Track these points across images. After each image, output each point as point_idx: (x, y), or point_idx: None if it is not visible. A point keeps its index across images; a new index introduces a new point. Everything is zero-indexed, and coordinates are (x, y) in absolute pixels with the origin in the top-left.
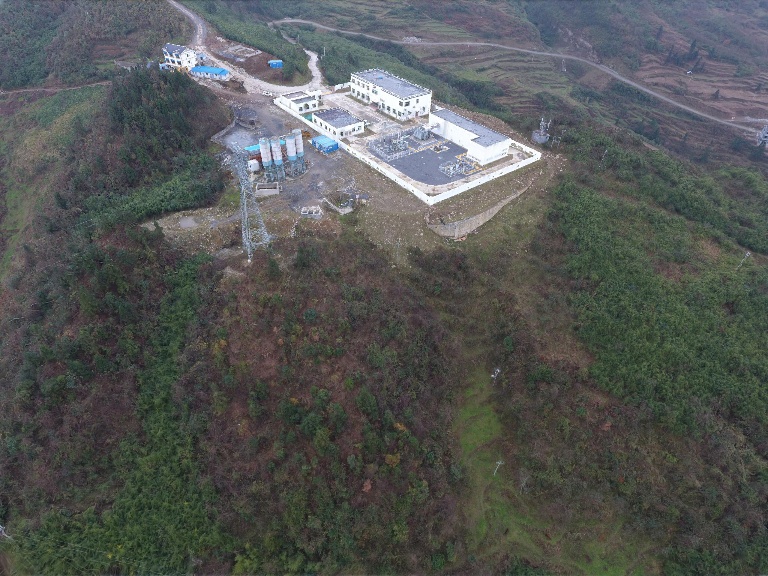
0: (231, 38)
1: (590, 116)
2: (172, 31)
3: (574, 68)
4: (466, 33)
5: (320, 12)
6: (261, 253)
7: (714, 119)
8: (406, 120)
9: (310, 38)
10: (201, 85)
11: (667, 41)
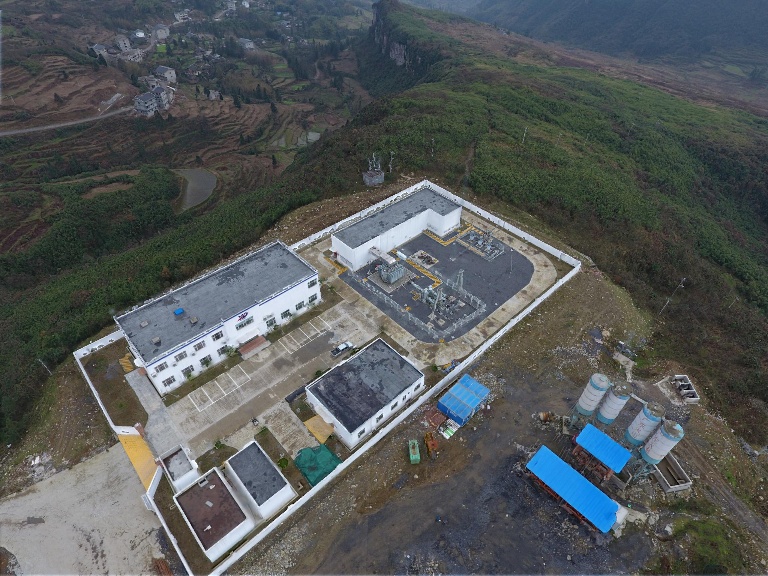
0: None
1: None
2: None
3: None
4: None
5: None
6: None
7: (93, 119)
8: None
9: None
10: None
11: None
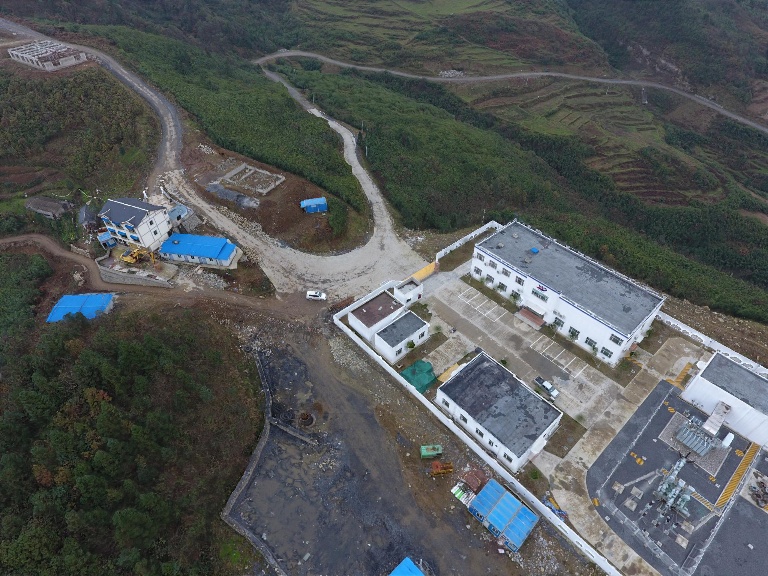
0: (225, 144)
1: (718, 181)
2: (122, 139)
3: (659, 99)
4: (517, 60)
5: (325, 40)
6: None
7: None
8: (618, 362)
9: (324, 88)
10: (185, 337)
11: None
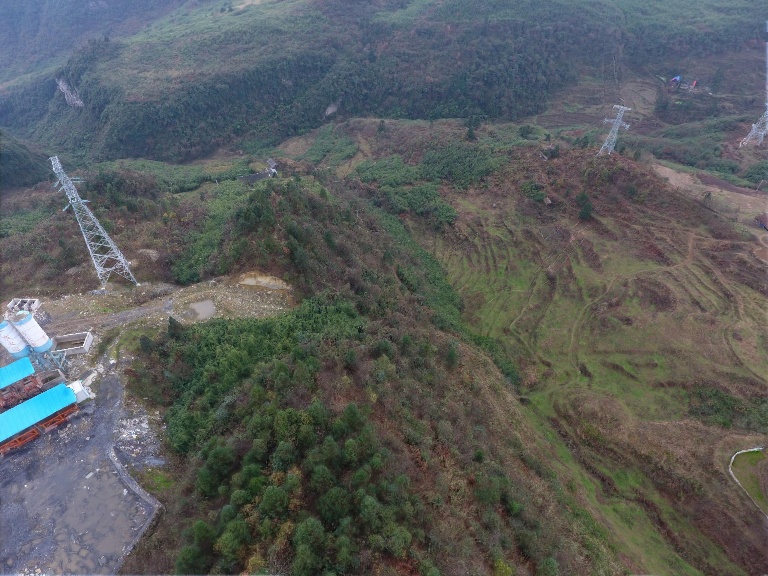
0: None
1: None
2: None
3: None
4: None
5: None
6: (115, 274)
7: None
8: None
9: None
10: None
11: None
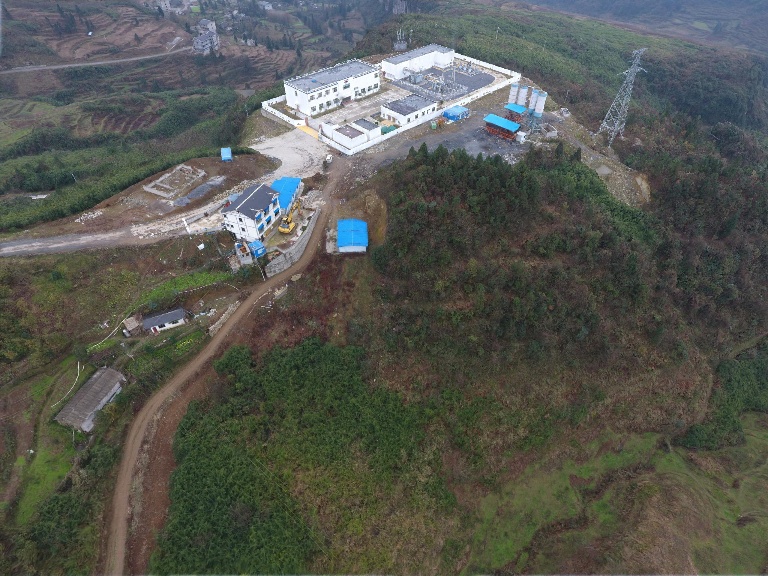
0: (84, 206)
1: None
2: None
3: None
4: None
5: None
6: None
7: (164, 54)
8: None
9: None
10: None
11: (26, 18)
